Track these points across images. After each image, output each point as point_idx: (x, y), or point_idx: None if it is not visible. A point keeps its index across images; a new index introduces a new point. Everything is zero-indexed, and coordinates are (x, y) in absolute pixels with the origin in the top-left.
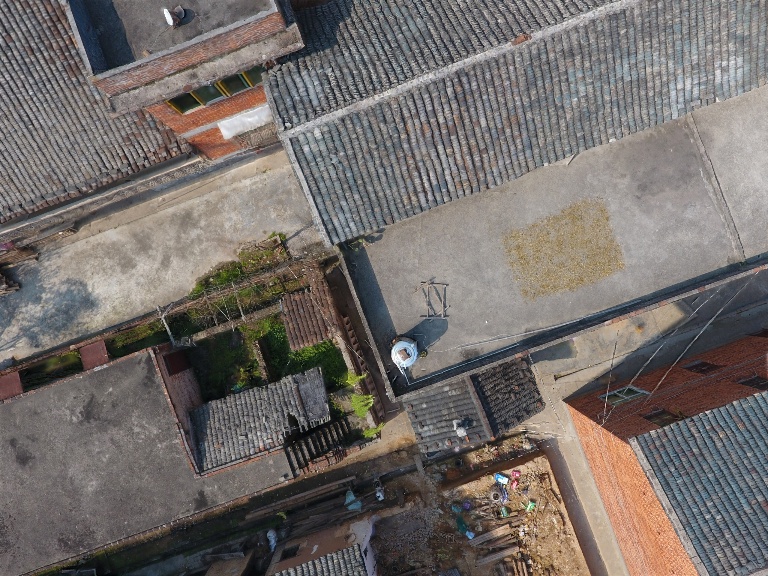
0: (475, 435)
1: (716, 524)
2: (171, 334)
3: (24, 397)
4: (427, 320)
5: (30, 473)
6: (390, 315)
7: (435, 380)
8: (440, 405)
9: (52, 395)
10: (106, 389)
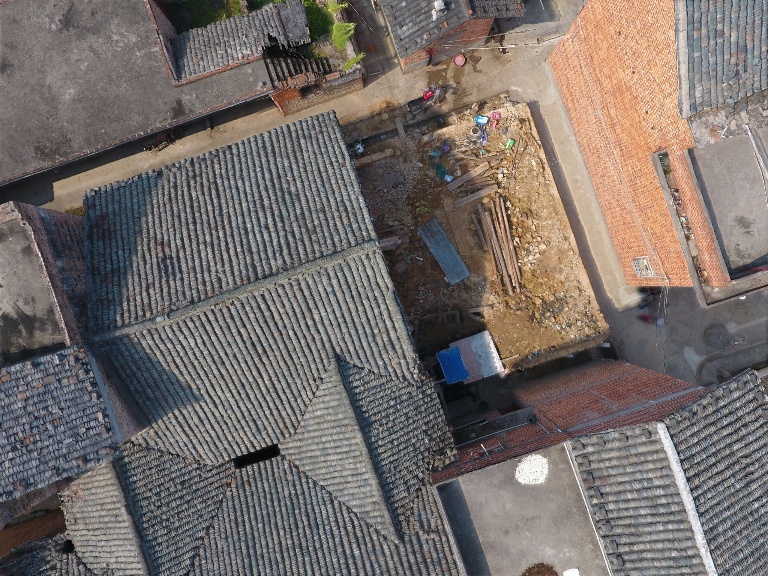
0: (453, 17)
1: None
2: None
3: (3, 4)
4: None
5: (8, 81)
6: None
7: None
8: None
9: (32, 3)
10: None
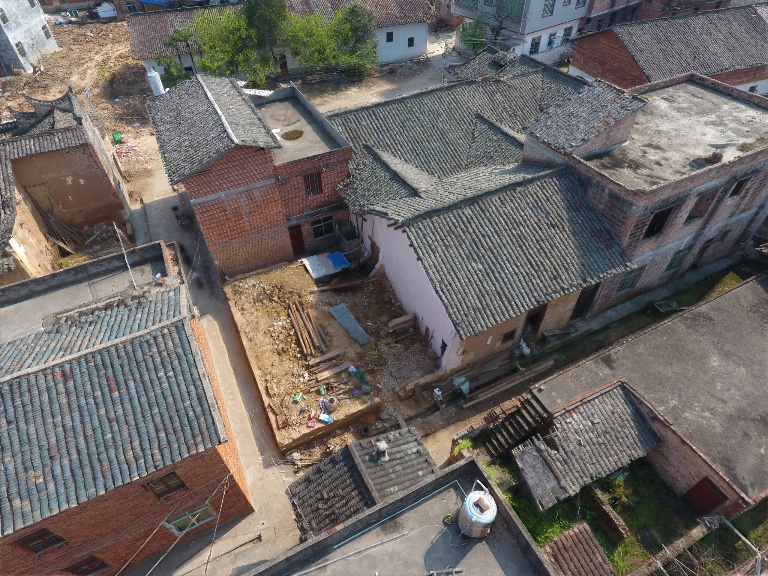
0: (366, 446)
1: (165, 368)
2: (735, 531)
3: None
4: (453, 567)
5: None
6: (501, 568)
7: (431, 487)
8: (404, 475)
9: None
10: (767, 451)
